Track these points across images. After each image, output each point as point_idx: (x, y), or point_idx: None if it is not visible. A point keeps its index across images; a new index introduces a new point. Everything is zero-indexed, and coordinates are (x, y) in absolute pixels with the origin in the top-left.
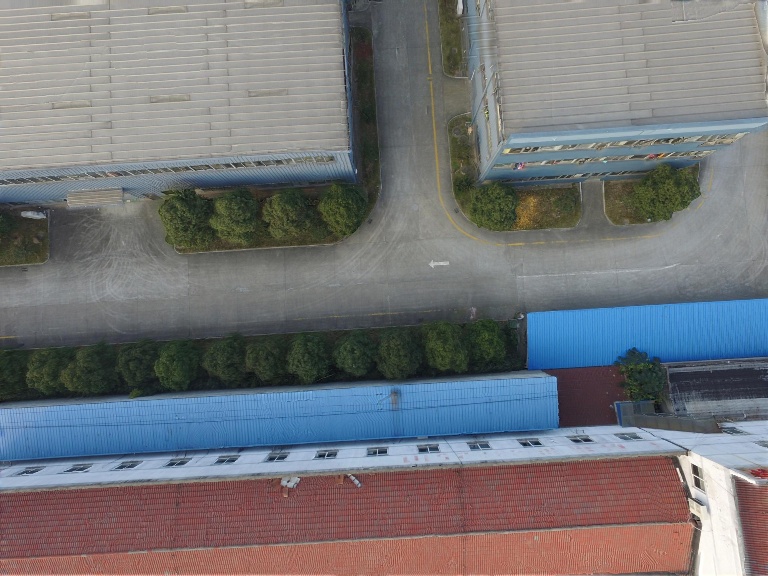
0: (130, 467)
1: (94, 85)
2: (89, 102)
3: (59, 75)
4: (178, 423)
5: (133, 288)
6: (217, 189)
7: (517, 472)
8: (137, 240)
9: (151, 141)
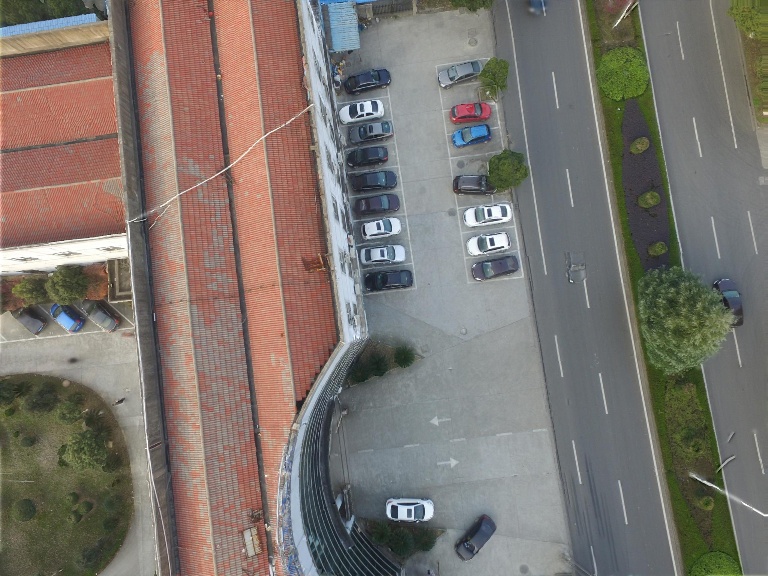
0: None
1: None
2: None
3: None
4: None
5: None
6: None
7: (20, 61)
8: None
9: None
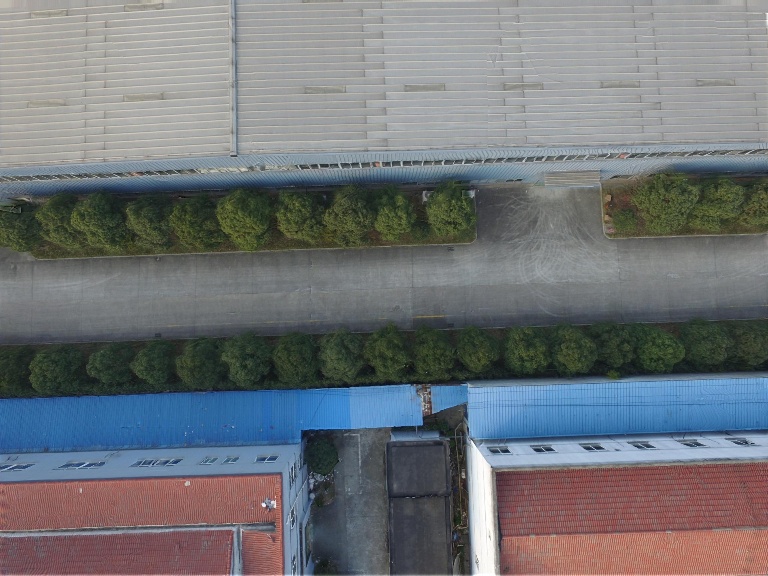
0: (650, 447)
1: (642, 66)
2: (638, 83)
3: (554, 55)
4: (678, 405)
5: (563, 271)
6: (680, 175)
7: None
8: (565, 223)
9: (689, 124)
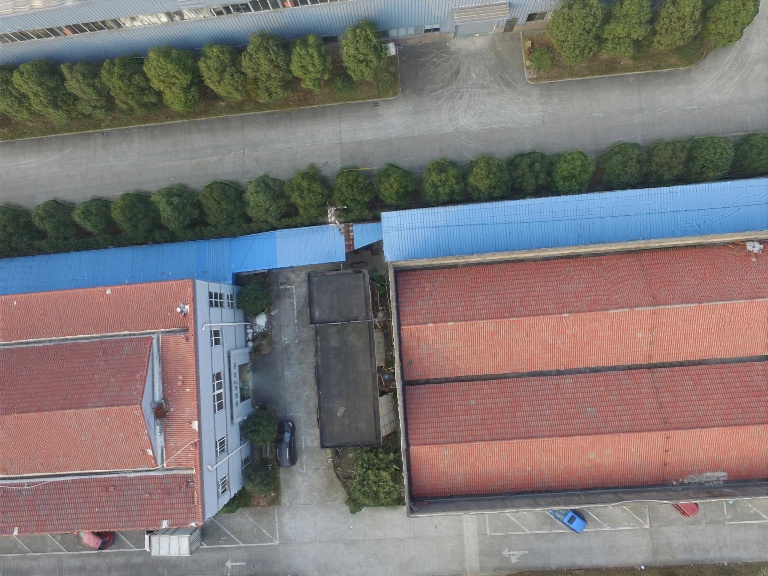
0: None
1: None
2: None
3: None
4: (591, 218)
5: (486, 118)
6: None
7: None
8: (487, 72)
9: None
